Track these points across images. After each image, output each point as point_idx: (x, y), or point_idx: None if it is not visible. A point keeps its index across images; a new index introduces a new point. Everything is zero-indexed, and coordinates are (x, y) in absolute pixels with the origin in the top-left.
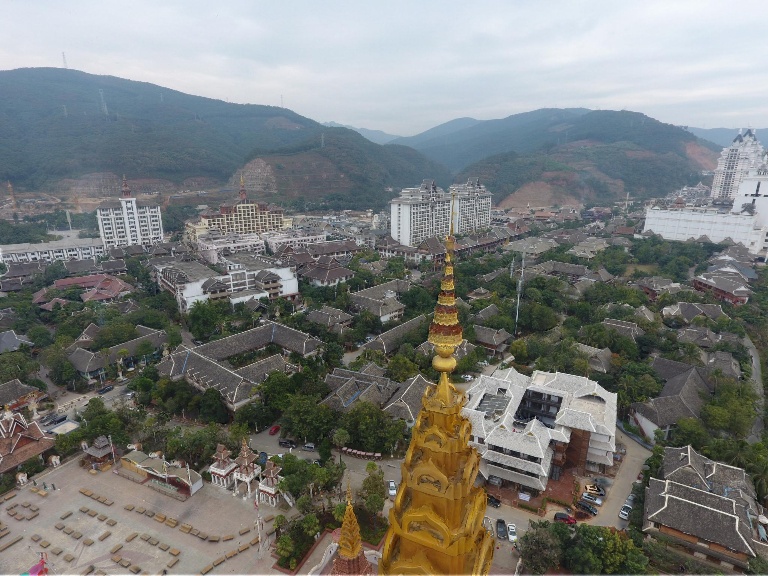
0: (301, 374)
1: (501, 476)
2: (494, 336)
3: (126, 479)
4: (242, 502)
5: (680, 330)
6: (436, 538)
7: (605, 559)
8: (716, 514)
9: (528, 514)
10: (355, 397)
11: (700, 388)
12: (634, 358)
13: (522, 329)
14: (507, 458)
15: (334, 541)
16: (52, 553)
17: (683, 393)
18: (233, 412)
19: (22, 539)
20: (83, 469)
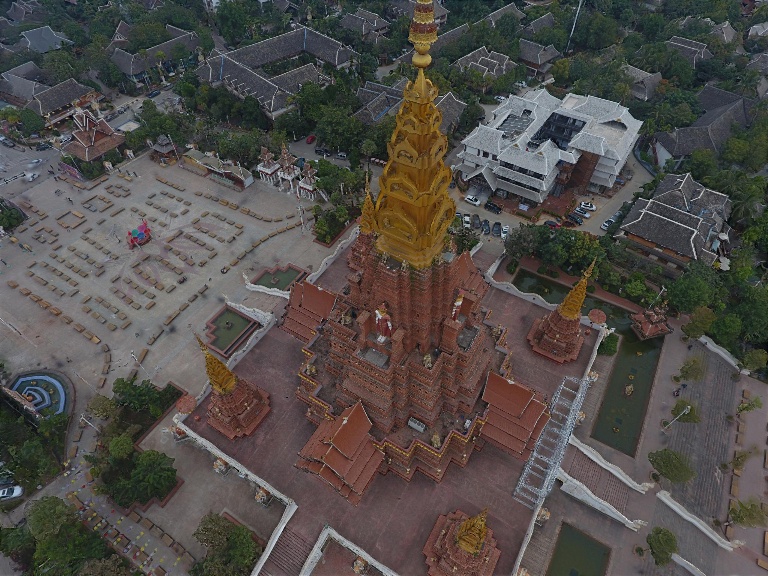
0: (334, 86)
1: (507, 189)
2: (540, 53)
3: (191, 172)
4: (287, 196)
5: (756, 55)
6: (409, 196)
7: (572, 253)
8: (680, 227)
9: (523, 220)
10: (385, 112)
11: (736, 121)
12: (684, 86)
13: (575, 46)
14: (515, 174)
15: (358, 224)
16: (149, 220)
17: (714, 125)
18: (272, 120)
19: (124, 210)
20: (154, 162)
